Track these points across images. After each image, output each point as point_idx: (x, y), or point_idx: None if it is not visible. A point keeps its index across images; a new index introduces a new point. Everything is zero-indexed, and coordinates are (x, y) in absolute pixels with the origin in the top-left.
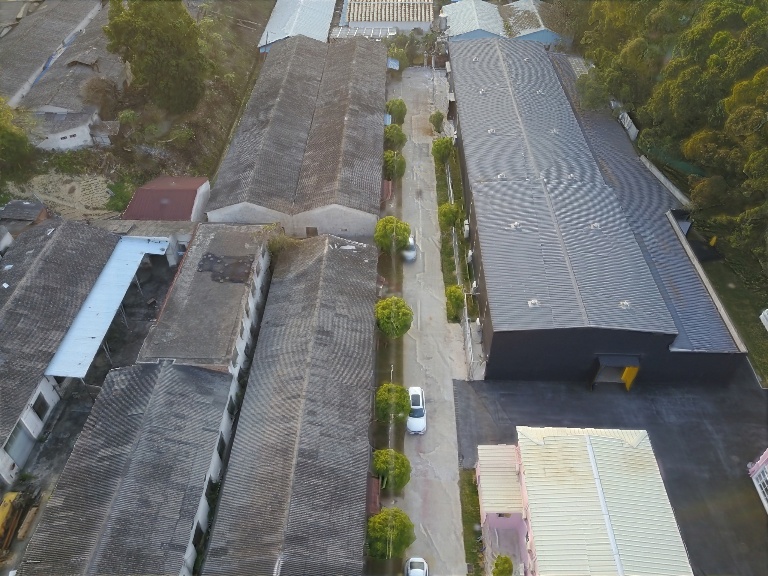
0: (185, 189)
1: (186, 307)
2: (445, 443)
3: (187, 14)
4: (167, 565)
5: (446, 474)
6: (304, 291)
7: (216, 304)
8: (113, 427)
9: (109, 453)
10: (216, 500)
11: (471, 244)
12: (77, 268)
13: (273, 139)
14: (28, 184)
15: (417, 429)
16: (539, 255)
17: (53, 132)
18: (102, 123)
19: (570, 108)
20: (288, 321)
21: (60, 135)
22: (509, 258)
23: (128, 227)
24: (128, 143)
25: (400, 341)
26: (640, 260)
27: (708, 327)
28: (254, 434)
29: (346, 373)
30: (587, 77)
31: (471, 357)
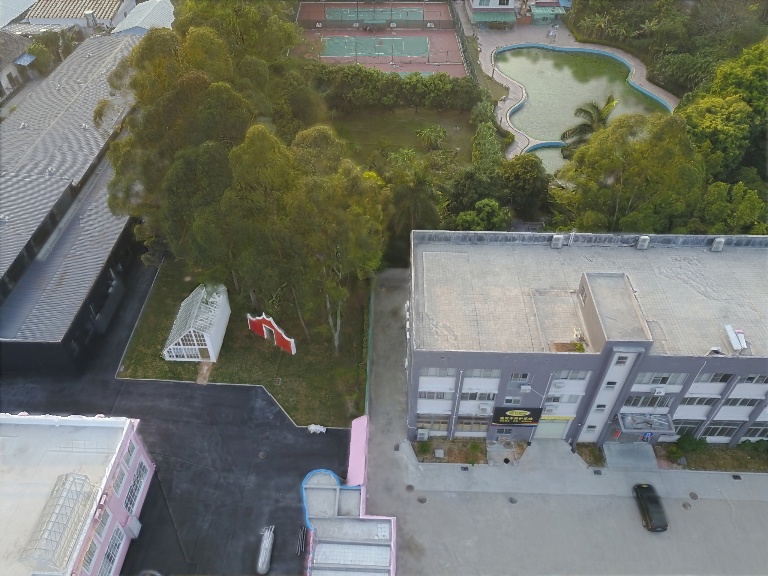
0: None
1: None
2: None
3: None
4: None
5: None
6: None
7: None
8: None
9: None
10: None
11: None
12: None
13: None
14: None
15: None
16: None
17: None
18: None
19: None
20: None
21: None
22: None
23: None
24: None
25: None
26: (14, 251)
27: (55, 317)
28: None
29: None
30: None
31: None
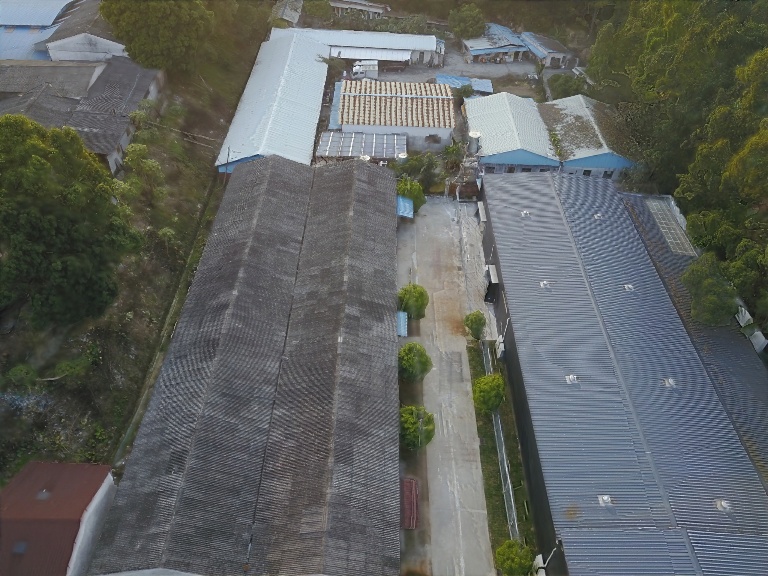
0: (59, 519)
1: None
2: None
3: (93, 165)
4: None
5: None
6: None
7: None
8: None
9: None
10: None
11: None
12: None
13: (222, 386)
14: None
15: None
16: None
17: None
18: None
19: (680, 322)
20: None
21: None
22: None
23: None
24: None
25: None
26: None
27: None
28: None
29: None
30: (703, 272)
31: None
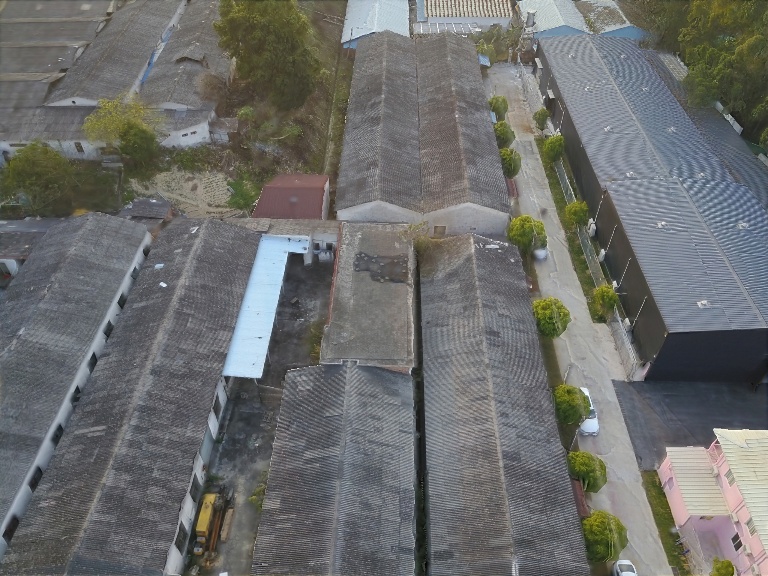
0: (313, 187)
1: (354, 307)
2: (620, 444)
3: (295, 10)
4: (402, 568)
5: (628, 476)
6: (461, 291)
7: (383, 304)
8: (311, 429)
9: (316, 455)
10: (422, 502)
11: (600, 243)
12: (228, 267)
13: (388, 136)
14: (151, 181)
15: (591, 430)
16: (696, 255)
17: (176, 129)
18: (220, 120)
19: (680, 106)
20: (452, 321)
21: (182, 132)
22: (665, 258)
23: (267, 225)
24: (244, 140)
25: (550, 341)
26: None
27: None
28: (447, 436)
29: (524, 374)
30: (696, 74)
31: (633, 358)
